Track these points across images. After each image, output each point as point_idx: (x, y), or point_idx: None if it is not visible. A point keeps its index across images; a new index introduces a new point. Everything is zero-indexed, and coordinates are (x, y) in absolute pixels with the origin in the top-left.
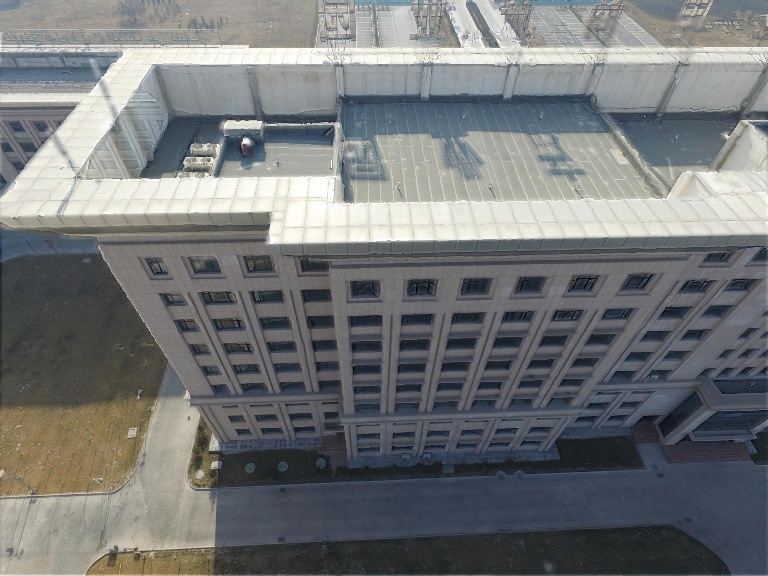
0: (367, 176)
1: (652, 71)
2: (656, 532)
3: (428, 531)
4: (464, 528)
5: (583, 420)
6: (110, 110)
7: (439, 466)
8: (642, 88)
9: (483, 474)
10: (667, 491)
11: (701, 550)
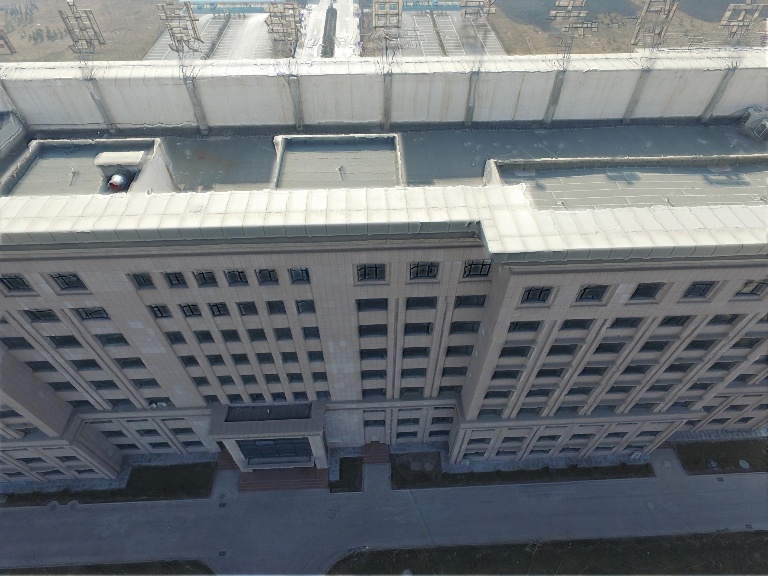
0: None
1: (63, 86)
2: (178, 567)
3: None
4: None
5: (164, 446)
6: None
7: None
8: (70, 103)
9: (34, 504)
10: (218, 522)
11: None
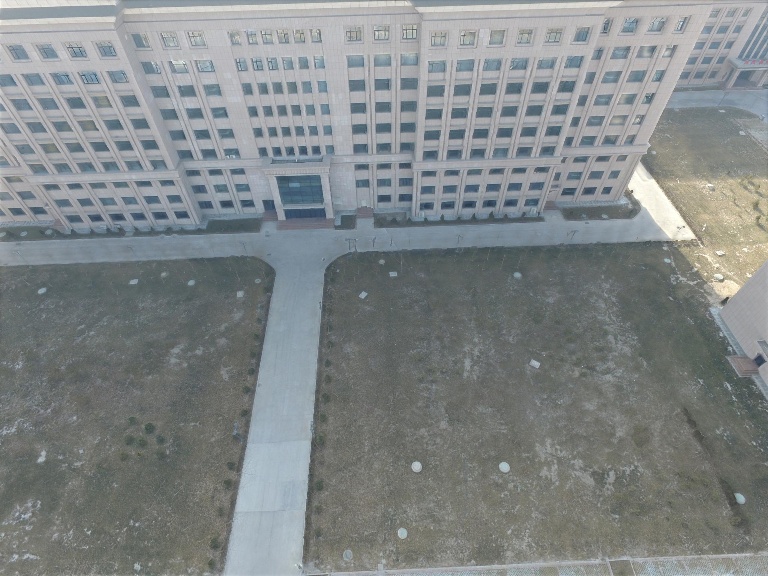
0: None
1: None
2: (243, 259)
3: (99, 260)
4: (122, 259)
5: (229, 207)
6: None
7: (118, 228)
8: None
9: (150, 236)
10: (265, 242)
11: (265, 267)
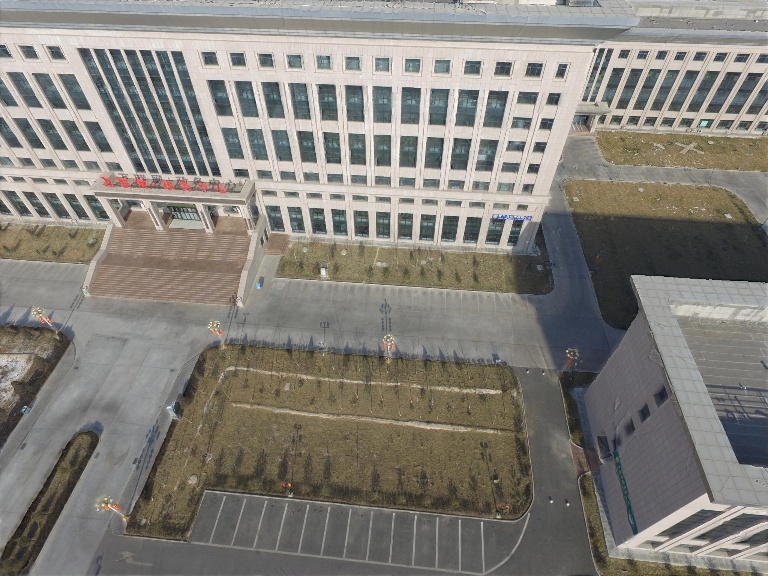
0: None
1: None
2: None
3: None
4: None
5: None
6: None
7: None
8: None
9: None
10: None
11: None
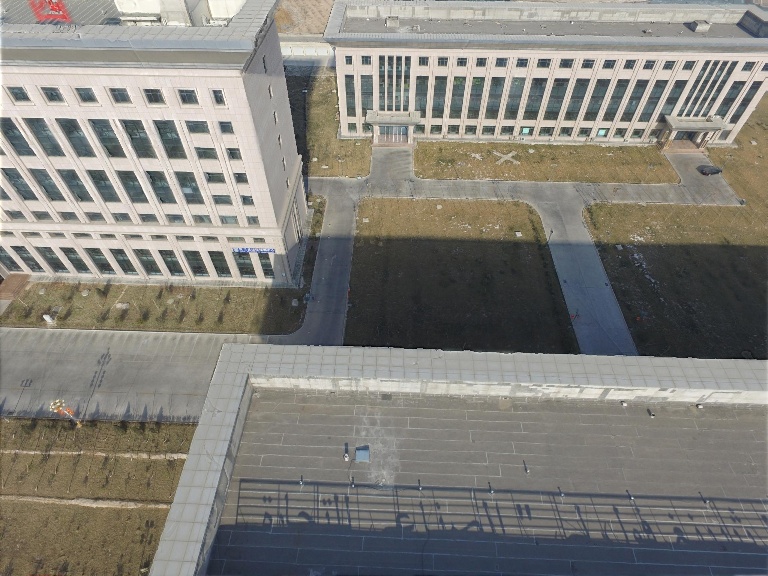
0: (117, 19)
1: None
2: None
3: None
4: None
5: None
6: (253, 0)
7: None
8: None
9: None
10: None
11: None
